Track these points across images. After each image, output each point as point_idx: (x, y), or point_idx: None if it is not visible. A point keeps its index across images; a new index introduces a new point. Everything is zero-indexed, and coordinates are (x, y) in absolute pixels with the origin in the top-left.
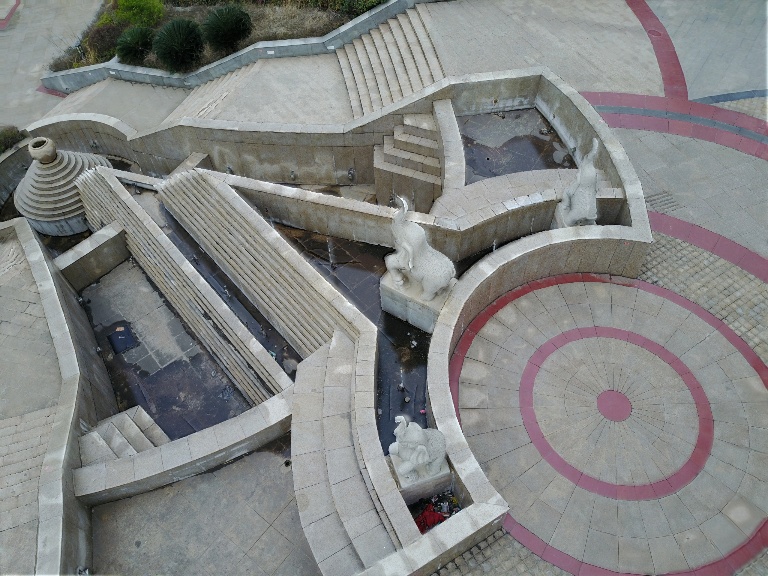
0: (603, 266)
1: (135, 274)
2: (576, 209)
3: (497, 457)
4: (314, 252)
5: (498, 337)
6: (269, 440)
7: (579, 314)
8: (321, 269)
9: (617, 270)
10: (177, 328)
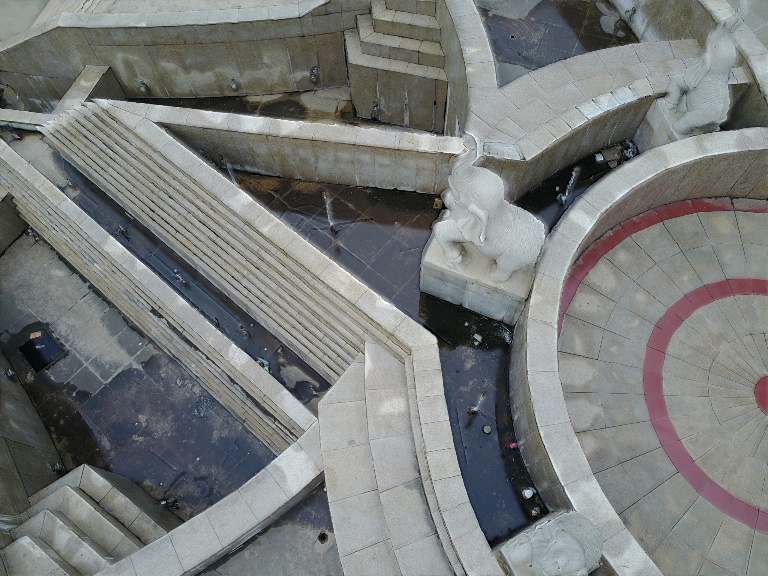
0: (724, 187)
1: (40, 252)
2: (701, 110)
3: (635, 503)
4: (301, 211)
5: (597, 314)
6: (289, 508)
7: (701, 264)
8: (317, 237)
9: (742, 191)
10: (116, 323)
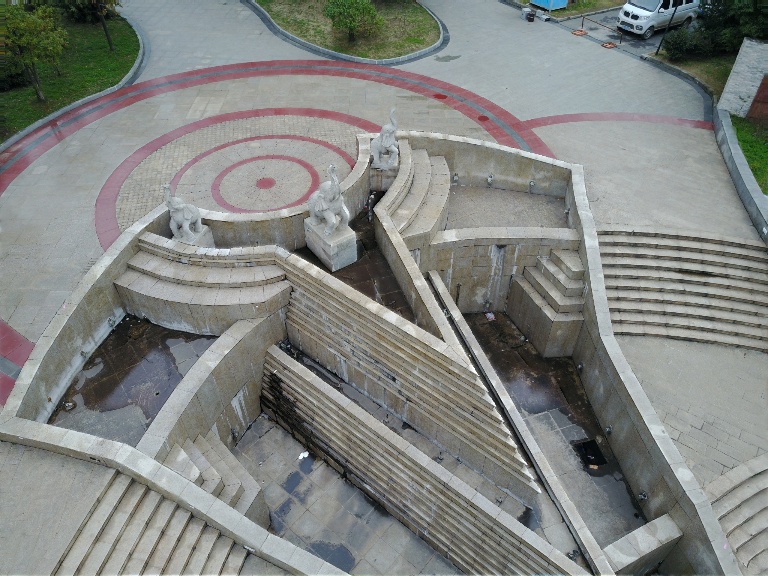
0: None
1: None
2: None
3: None
4: None
5: None
6: None
7: None
8: (387, 301)
9: None
10: None
